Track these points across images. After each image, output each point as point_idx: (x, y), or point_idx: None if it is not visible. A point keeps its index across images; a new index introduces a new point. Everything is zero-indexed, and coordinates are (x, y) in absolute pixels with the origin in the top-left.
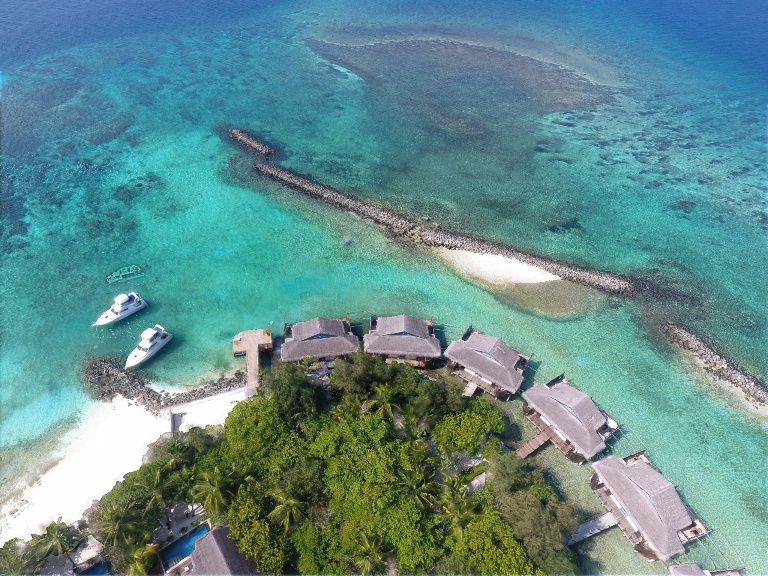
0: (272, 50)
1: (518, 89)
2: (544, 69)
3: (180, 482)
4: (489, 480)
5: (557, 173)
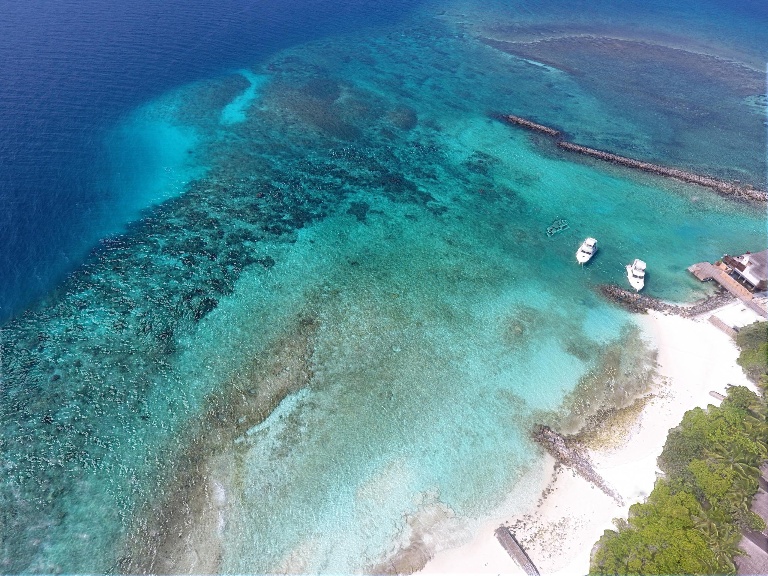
0: (459, 48)
1: (701, 77)
2: (705, 60)
3: None
4: None
5: None
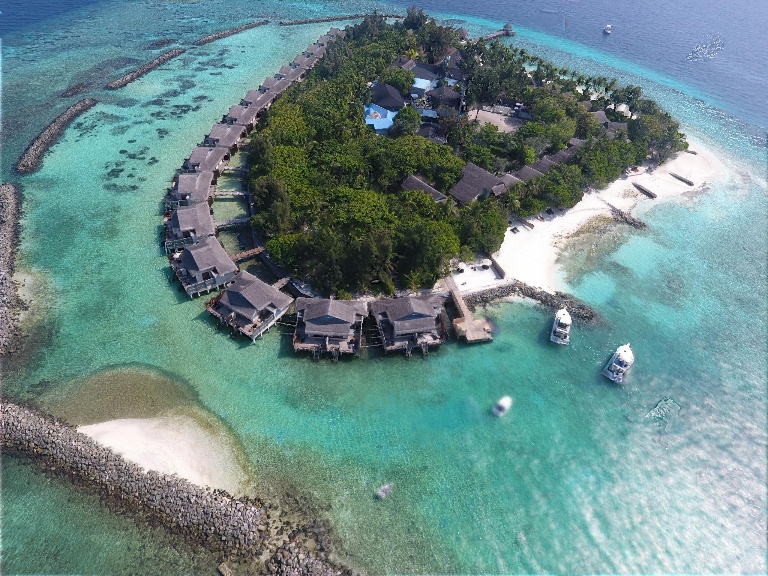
0: None
1: None
2: None
3: None
4: None
5: None
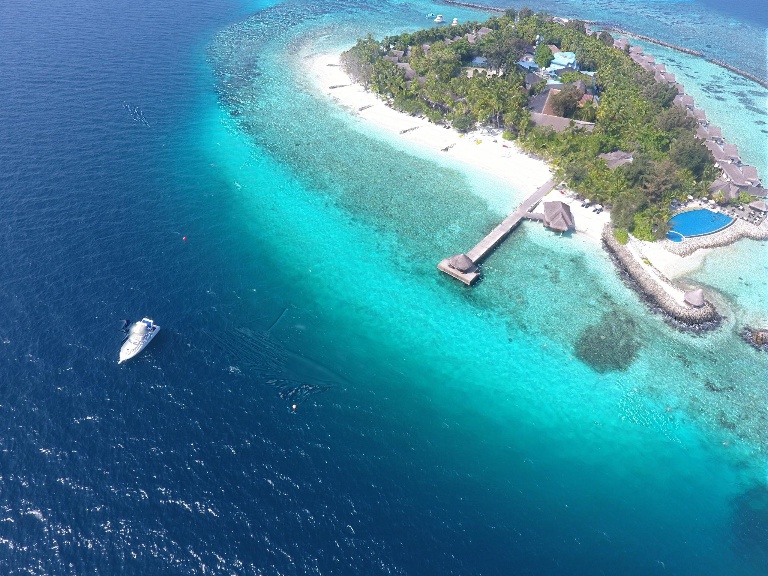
0: None
1: None
2: None
3: (495, 22)
4: None
5: (566, 6)
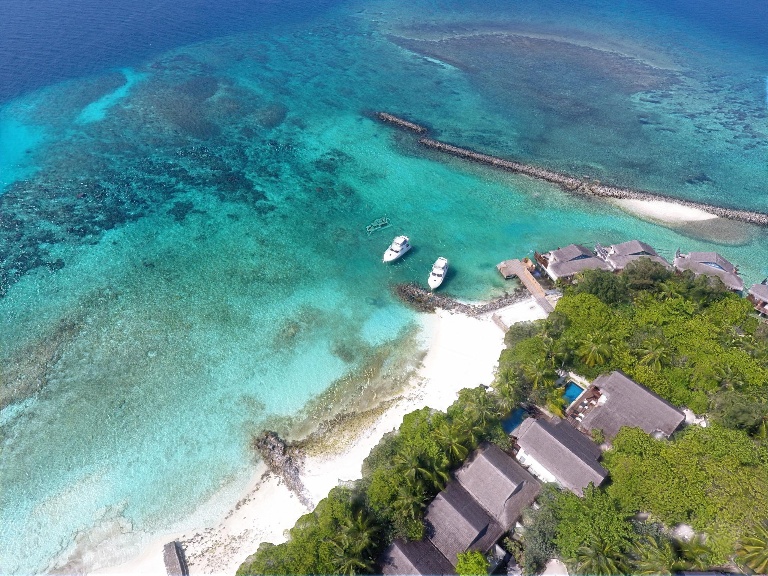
0: (362, 46)
1: (596, 74)
2: (608, 57)
3: (566, 346)
4: (764, 341)
5: (668, 140)
